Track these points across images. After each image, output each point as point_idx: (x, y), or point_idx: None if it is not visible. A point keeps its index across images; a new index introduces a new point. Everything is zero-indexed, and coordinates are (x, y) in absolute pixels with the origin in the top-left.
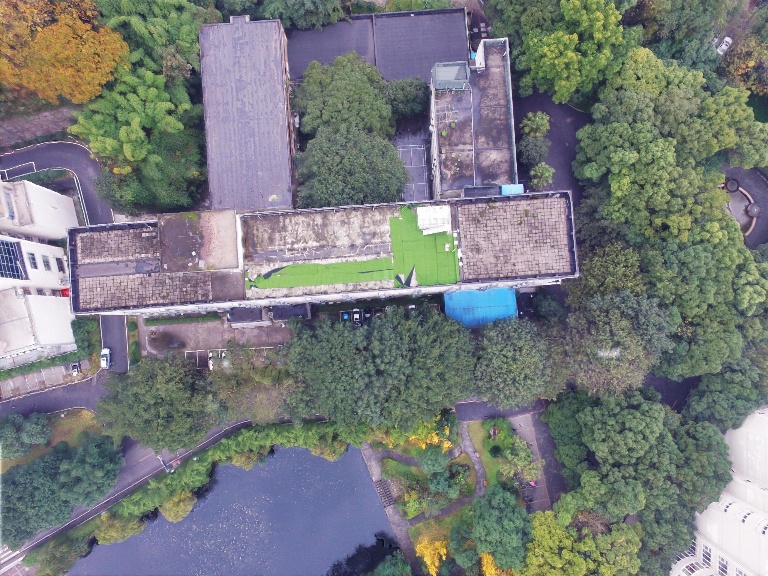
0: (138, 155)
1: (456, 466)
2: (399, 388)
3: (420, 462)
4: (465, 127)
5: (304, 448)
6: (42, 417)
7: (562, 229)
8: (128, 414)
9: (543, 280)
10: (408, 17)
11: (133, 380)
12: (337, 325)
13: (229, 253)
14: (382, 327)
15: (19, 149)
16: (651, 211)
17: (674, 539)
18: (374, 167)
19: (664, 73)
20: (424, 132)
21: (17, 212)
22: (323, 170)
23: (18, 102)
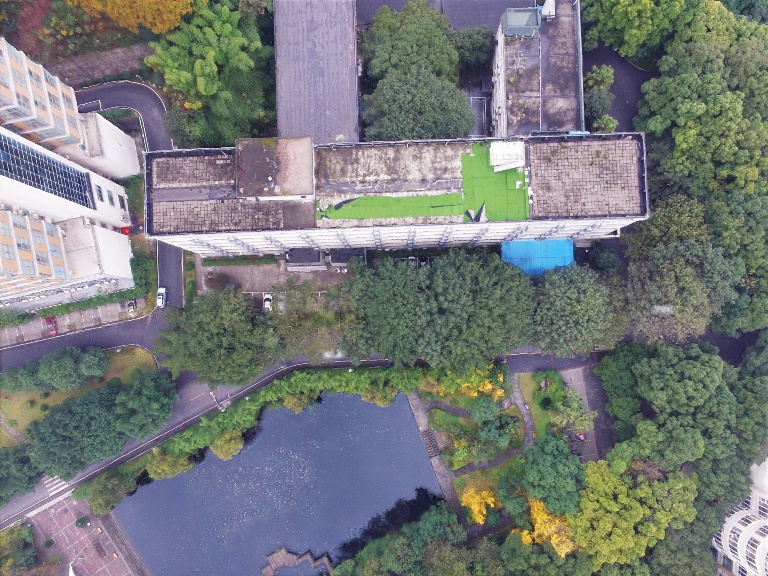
0: (210, 90)
1: (505, 417)
2: (460, 327)
3: (471, 410)
4: (533, 74)
5: (352, 395)
6: (99, 350)
7: (633, 171)
8: (192, 341)
9: (608, 226)
10: None
11: (198, 309)
12: (400, 263)
13: (305, 179)
14: (444, 268)
15: (86, 87)
16: (716, 164)
17: (730, 490)
18: (444, 107)
19: (735, 26)
20: (485, 85)
21: (87, 143)
22: (394, 108)
23: (93, 36)
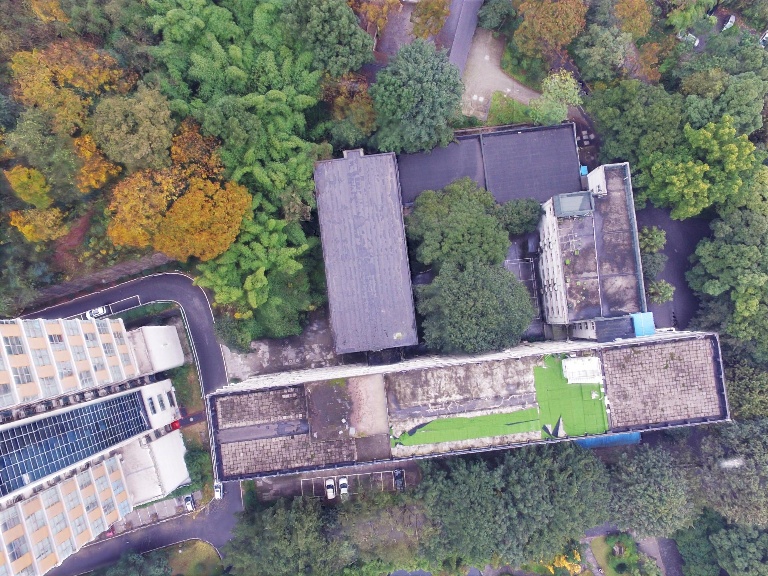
0: (260, 300)
1: None
2: (541, 530)
3: None
4: (588, 254)
5: None
6: (162, 557)
7: (709, 371)
8: (269, 571)
9: None
10: (515, 134)
11: (270, 534)
12: (473, 467)
13: (379, 418)
14: (517, 465)
15: (123, 283)
16: None
17: None
18: (506, 307)
19: None
20: (531, 245)
21: (136, 360)
22: (456, 314)
23: None
